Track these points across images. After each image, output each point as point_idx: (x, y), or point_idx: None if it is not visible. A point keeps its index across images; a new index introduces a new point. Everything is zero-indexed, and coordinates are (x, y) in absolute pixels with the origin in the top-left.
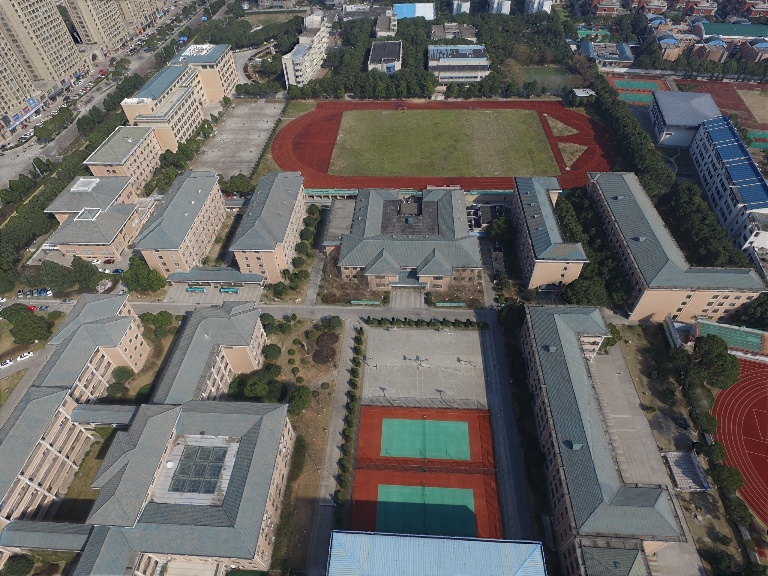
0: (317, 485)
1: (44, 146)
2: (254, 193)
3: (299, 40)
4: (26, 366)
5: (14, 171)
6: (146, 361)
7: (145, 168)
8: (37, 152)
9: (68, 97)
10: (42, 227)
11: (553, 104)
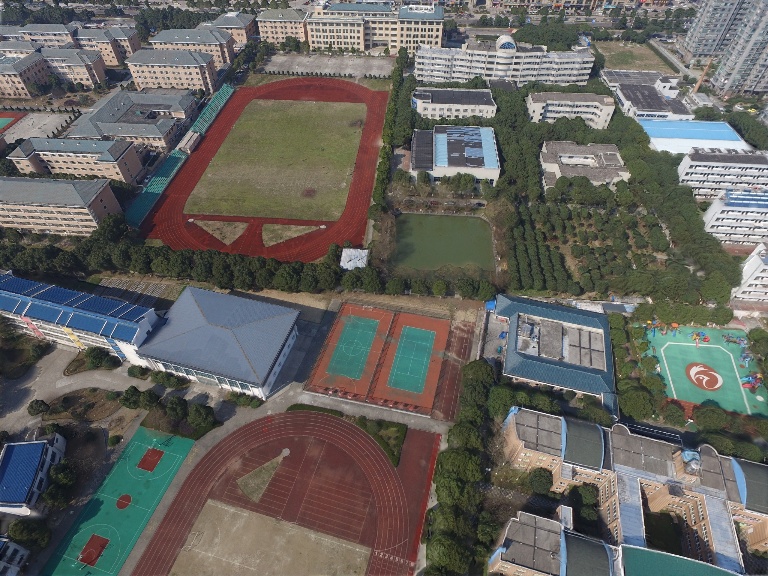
0: (1, 104)
1: None
2: None
3: (463, 46)
4: None
5: None
6: (111, 65)
7: (280, 38)
8: None
9: None
10: None
11: (352, 239)
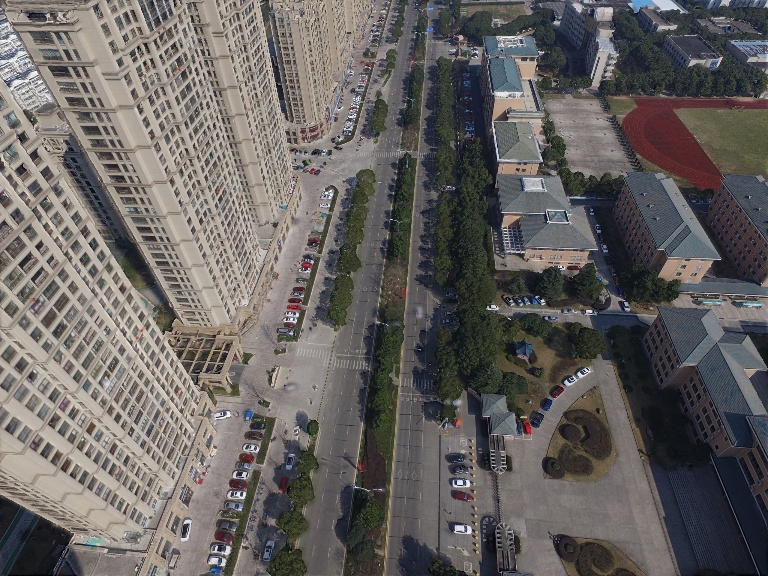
0: None
1: (376, 140)
2: (738, 198)
3: (599, 33)
4: (593, 384)
5: (369, 166)
6: None
7: None
8: (374, 146)
9: (354, 89)
10: (483, 228)
11: None
